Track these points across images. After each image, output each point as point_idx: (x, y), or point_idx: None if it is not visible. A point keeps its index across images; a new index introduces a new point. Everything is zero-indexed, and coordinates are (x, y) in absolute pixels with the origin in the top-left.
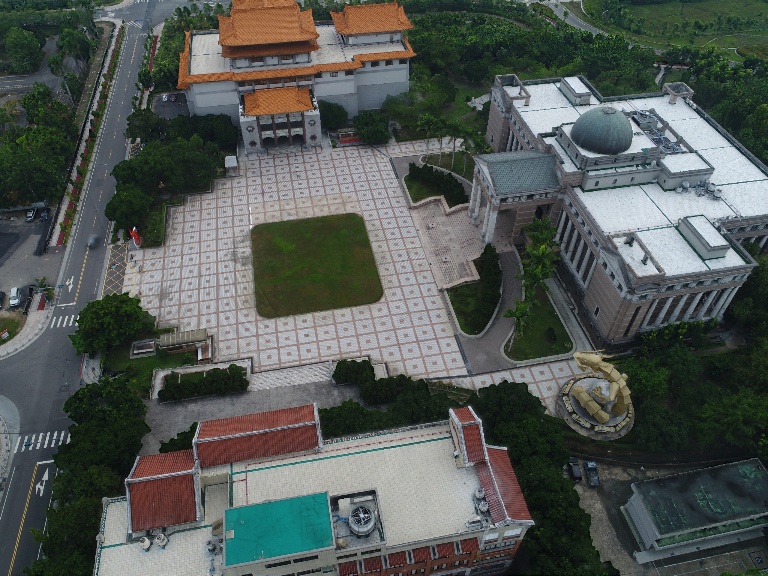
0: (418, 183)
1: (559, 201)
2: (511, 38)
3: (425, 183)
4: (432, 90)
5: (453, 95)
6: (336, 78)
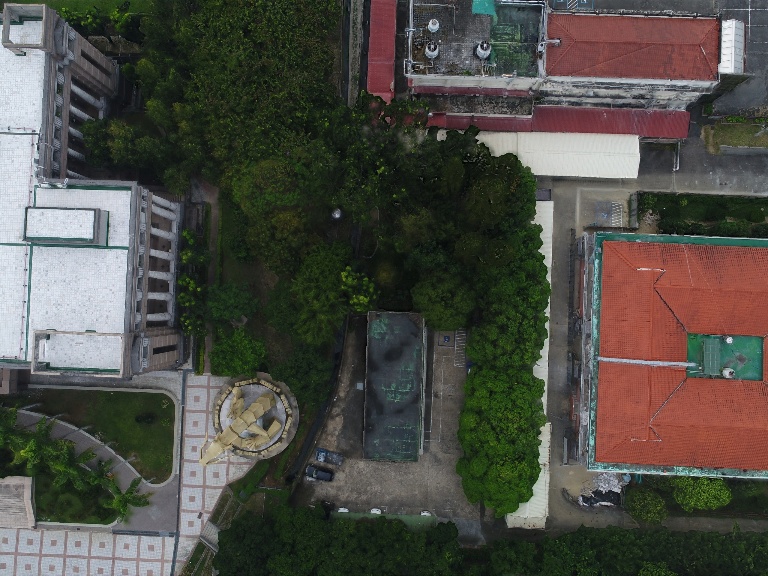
0: None
1: None
2: None
3: None
4: None
5: None
6: None
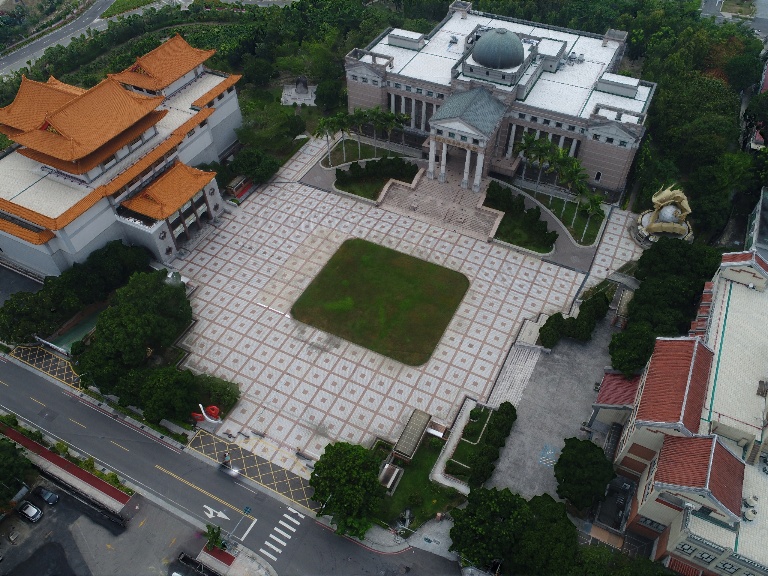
0: (353, 184)
1: (508, 119)
2: (253, 32)
3: (360, 180)
4: (259, 106)
5: None
6: (193, 136)
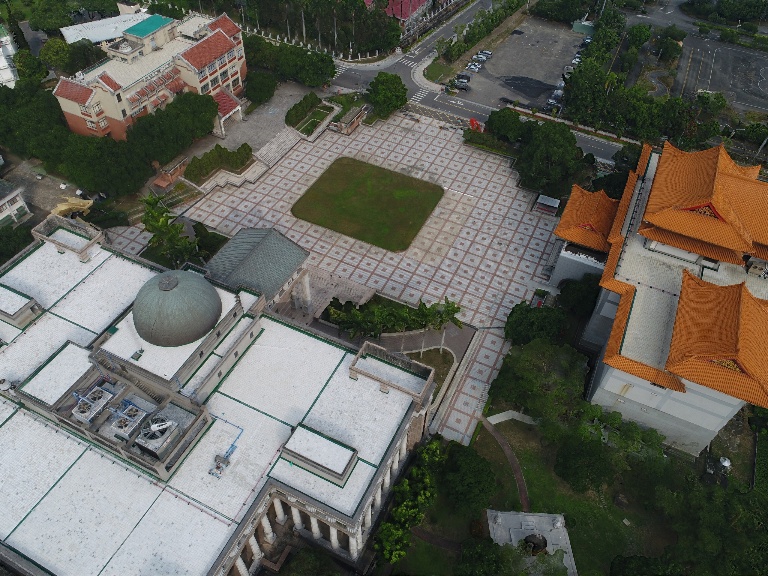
0: None
1: None
2: None
3: None
4: None
5: (566, 470)
6: None
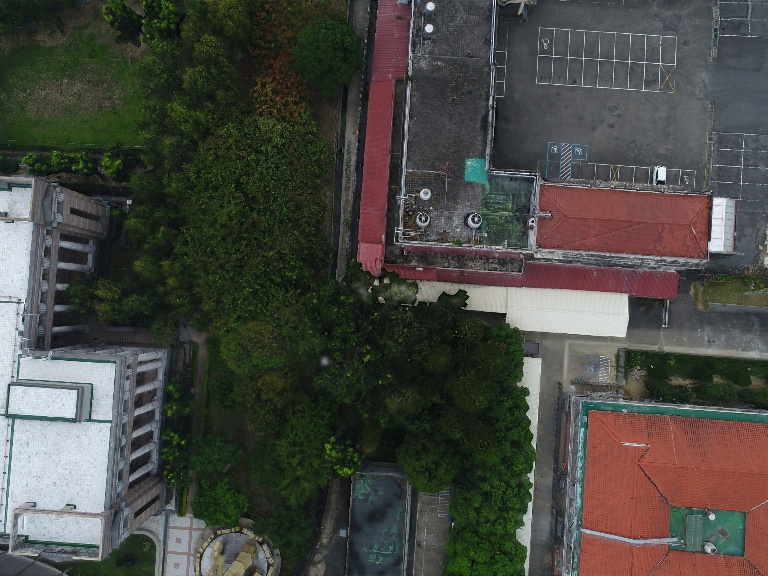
0: None
1: None
2: None
3: None
4: None
5: None
6: None
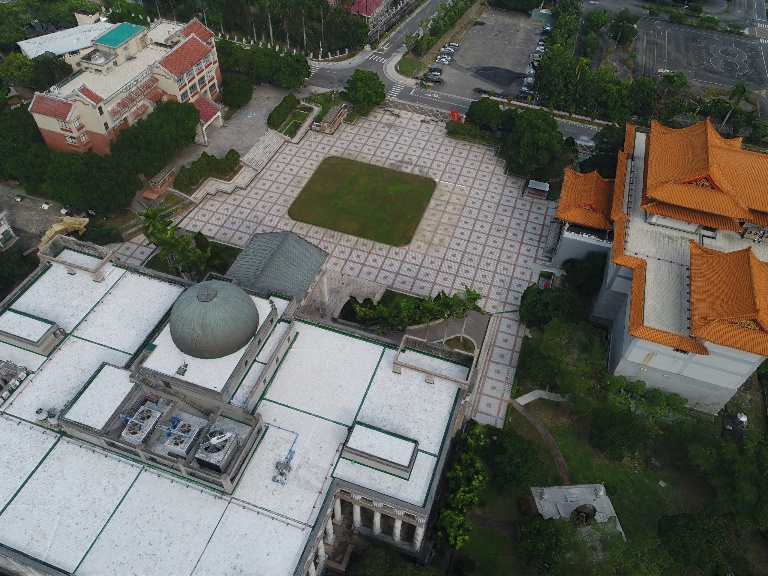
0: None
1: None
2: None
3: None
4: None
5: (602, 441)
6: None
